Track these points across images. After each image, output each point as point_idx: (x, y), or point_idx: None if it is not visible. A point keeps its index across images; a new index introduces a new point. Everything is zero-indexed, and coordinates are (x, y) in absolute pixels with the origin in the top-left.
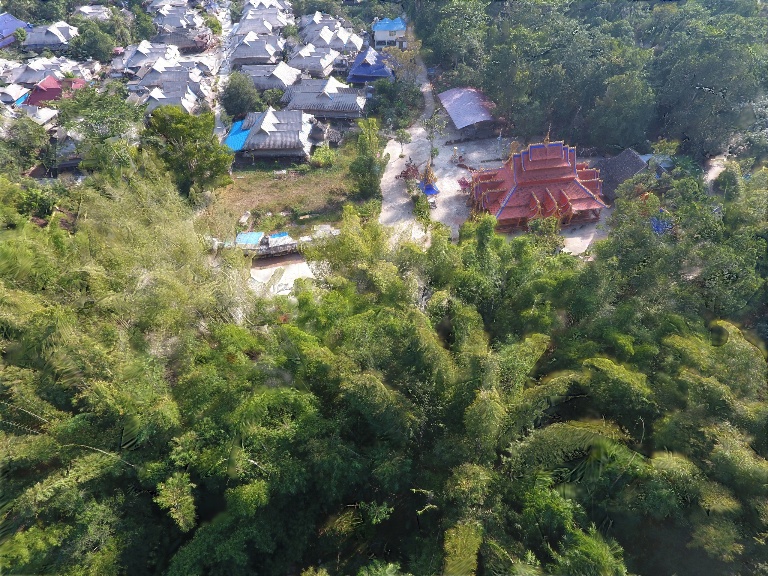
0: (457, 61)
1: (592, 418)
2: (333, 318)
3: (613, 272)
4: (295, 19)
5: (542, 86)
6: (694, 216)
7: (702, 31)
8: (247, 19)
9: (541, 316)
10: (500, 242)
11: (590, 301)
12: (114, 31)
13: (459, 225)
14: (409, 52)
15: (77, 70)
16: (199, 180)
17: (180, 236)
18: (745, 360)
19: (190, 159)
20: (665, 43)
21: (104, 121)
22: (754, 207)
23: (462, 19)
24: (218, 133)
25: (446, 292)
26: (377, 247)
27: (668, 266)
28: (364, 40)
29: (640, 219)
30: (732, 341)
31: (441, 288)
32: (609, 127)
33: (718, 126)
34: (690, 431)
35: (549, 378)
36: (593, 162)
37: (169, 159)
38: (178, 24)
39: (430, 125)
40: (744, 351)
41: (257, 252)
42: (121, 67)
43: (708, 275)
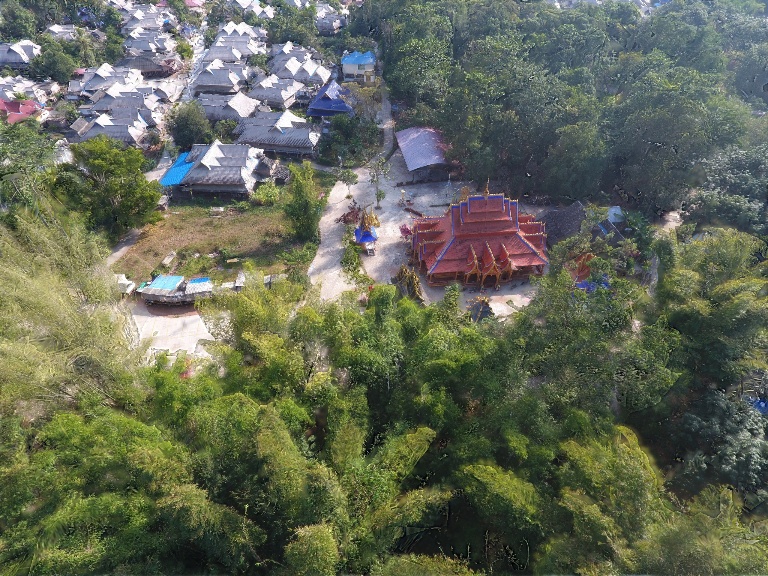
0: (417, 100)
1: (474, 533)
2: (190, 403)
3: (524, 352)
4: (266, 48)
5: (495, 131)
6: (600, 303)
7: (657, 84)
8: (215, 46)
9: (434, 404)
10: (407, 311)
11: (489, 389)
12: (78, 52)
13: (391, 278)
14: (367, 89)
15: (30, 91)
16: (122, 217)
17: (33, 299)
18: (634, 486)
19: (113, 195)
20: (629, 91)
21: (1, 157)
22: (680, 286)
23: (422, 58)
24: (164, 163)
25: (326, 374)
26: (271, 312)
27: (572, 356)
28: (332, 72)
29: (548, 299)
30: (620, 462)
31: (330, 365)
32: (559, 178)
33: (671, 182)
34: (566, 571)
35: (435, 479)
36: (545, 211)
37: (90, 194)
38: (147, 47)
39: (374, 168)
40: (633, 475)
41: (171, 299)
42: (78, 89)
43: (614, 370)
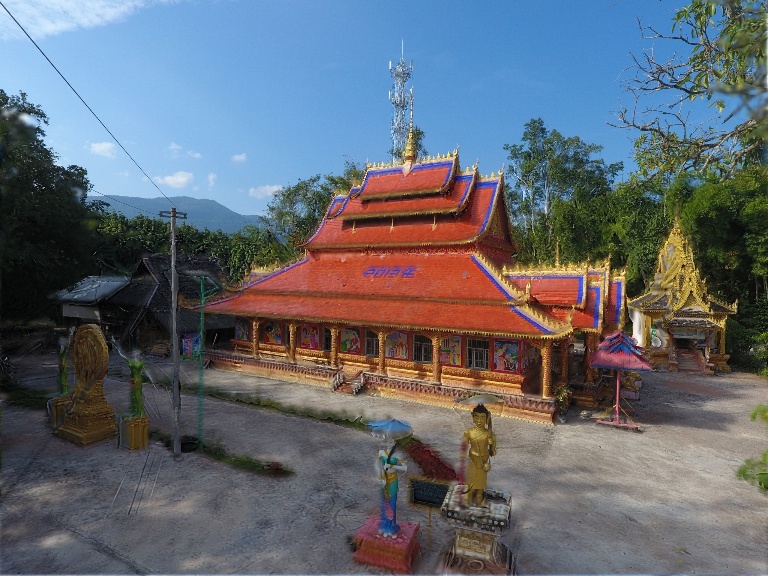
0: None
1: None
2: None
3: None
4: None
5: None
6: None
7: None
8: None
9: None
10: None
11: None
12: None
13: None
14: None
15: None
16: None
17: None
18: None
19: None
20: None
21: None
22: None
23: None
24: None
25: None
26: None
27: None
28: None
29: None
30: None
31: None
32: None
33: None
34: None
35: None
36: (55, 363)
37: None
38: None
39: None
40: None
41: None
42: None
43: None
